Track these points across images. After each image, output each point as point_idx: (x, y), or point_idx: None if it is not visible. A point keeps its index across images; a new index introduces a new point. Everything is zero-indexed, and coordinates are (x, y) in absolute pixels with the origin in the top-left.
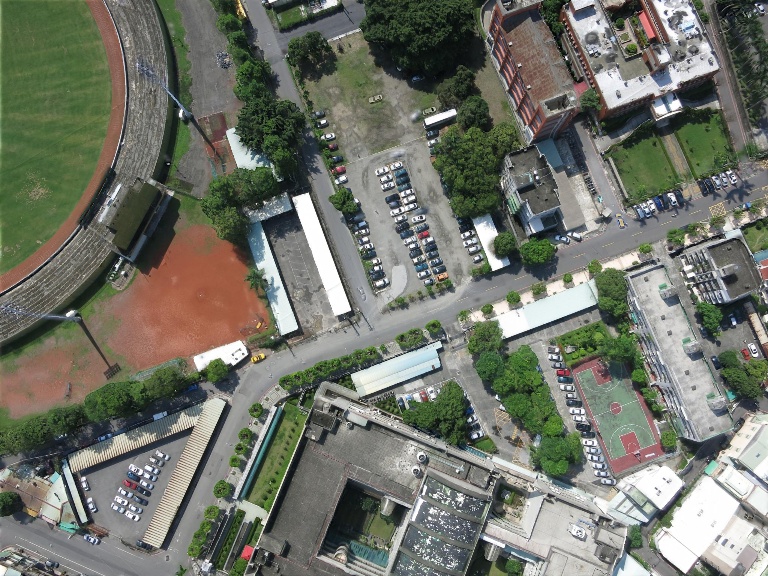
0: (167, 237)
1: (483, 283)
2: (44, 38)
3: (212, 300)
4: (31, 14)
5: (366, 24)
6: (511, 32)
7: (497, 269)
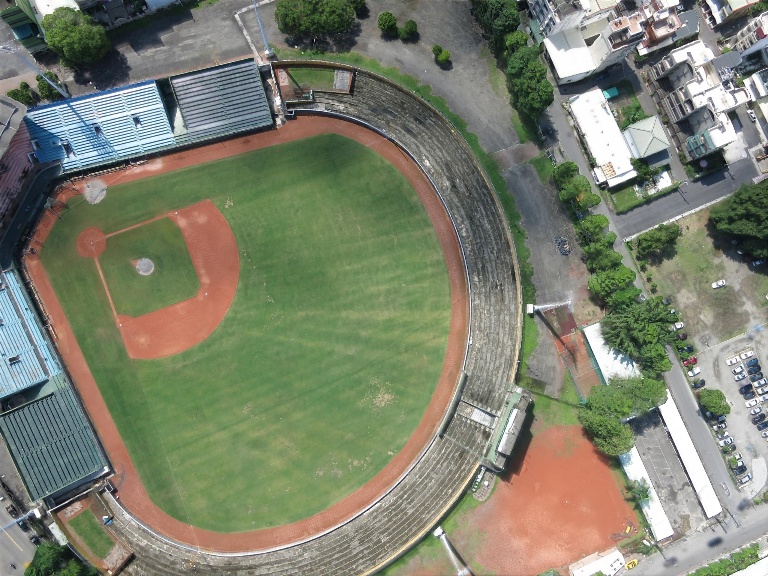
0: (525, 441)
1: None
2: (370, 226)
3: (578, 506)
4: (353, 199)
5: (726, 217)
6: None
7: None
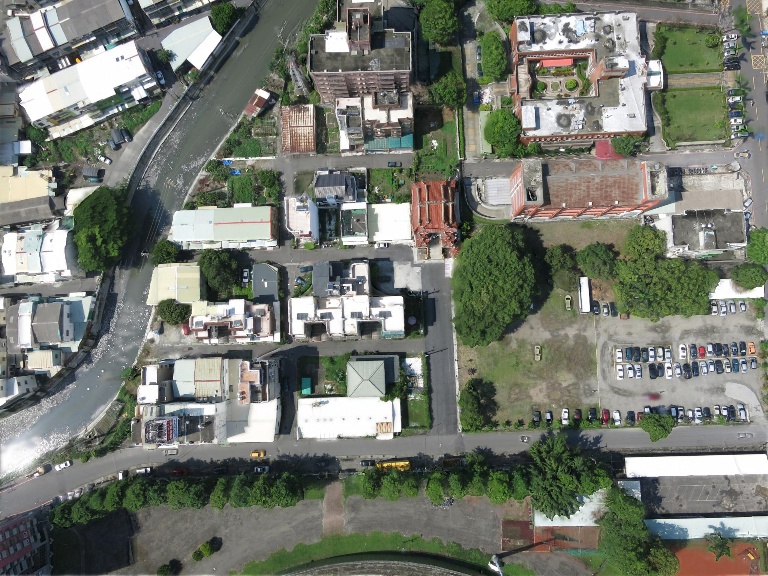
0: None
1: (767, 310)
2: None
3: None
4: None
5: (476, 341)
6: (552, 200)
7: (764, 292)
